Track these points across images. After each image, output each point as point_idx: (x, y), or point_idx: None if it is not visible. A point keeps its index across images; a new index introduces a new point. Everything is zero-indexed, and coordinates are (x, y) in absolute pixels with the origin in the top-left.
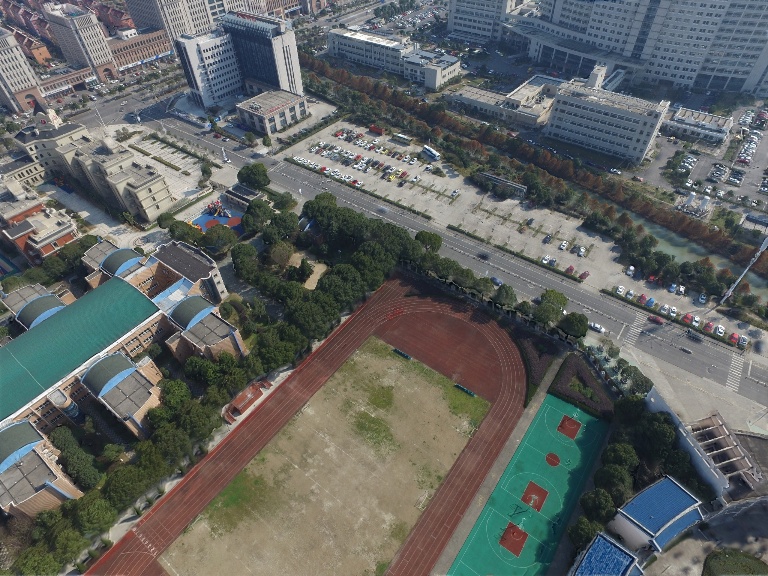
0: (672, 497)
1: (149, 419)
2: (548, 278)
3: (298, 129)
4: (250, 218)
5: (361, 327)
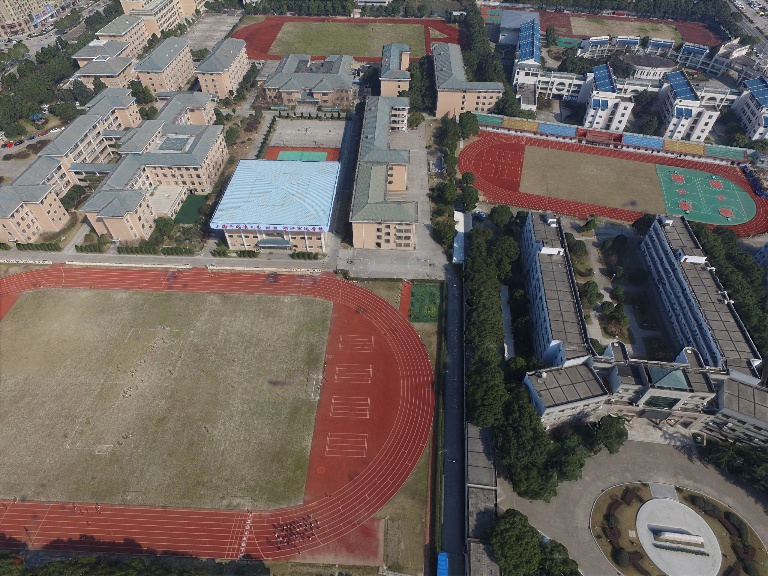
0: None
1: None
2: None
3: None
4: None
5: None
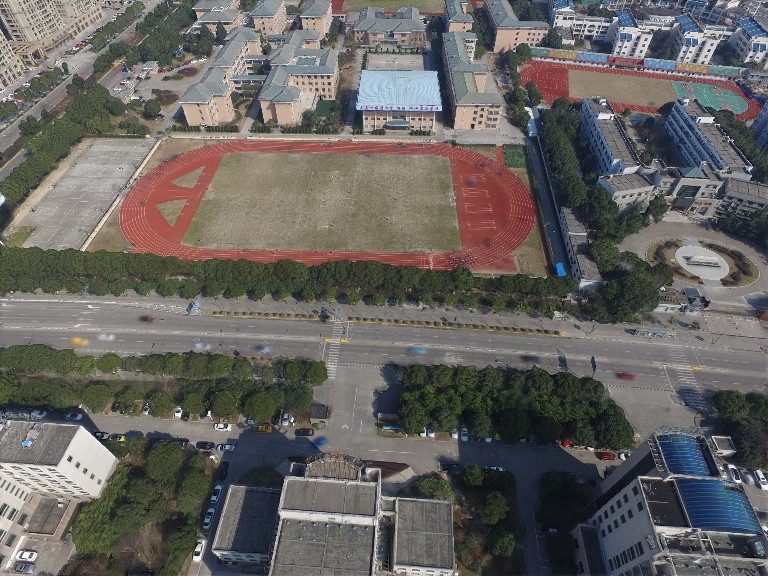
0: None
1: None
2: (757, 4)
3: None
4: None
5: None
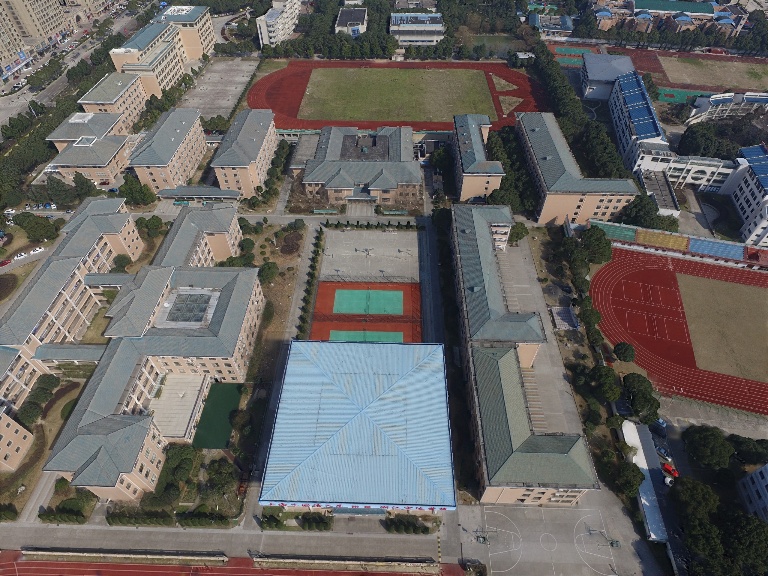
0: None
1: None
2: None
3: None
4: None
5: None
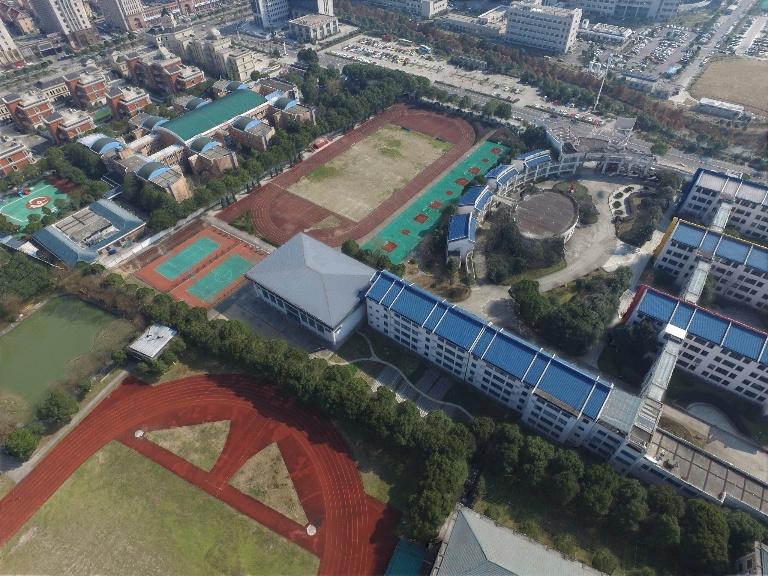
0: (537, 152)
1: (271, 142)
2: None
3: (332, 38)
4: (310, 73)
5: (382, 120)
